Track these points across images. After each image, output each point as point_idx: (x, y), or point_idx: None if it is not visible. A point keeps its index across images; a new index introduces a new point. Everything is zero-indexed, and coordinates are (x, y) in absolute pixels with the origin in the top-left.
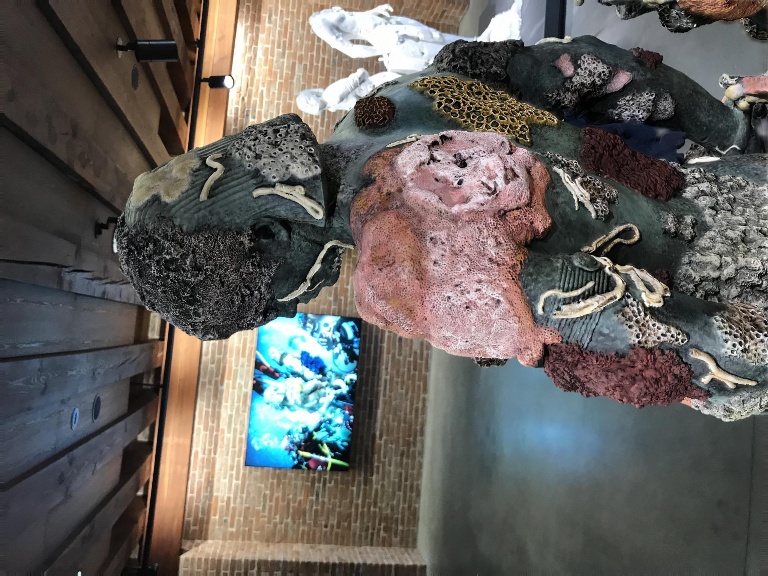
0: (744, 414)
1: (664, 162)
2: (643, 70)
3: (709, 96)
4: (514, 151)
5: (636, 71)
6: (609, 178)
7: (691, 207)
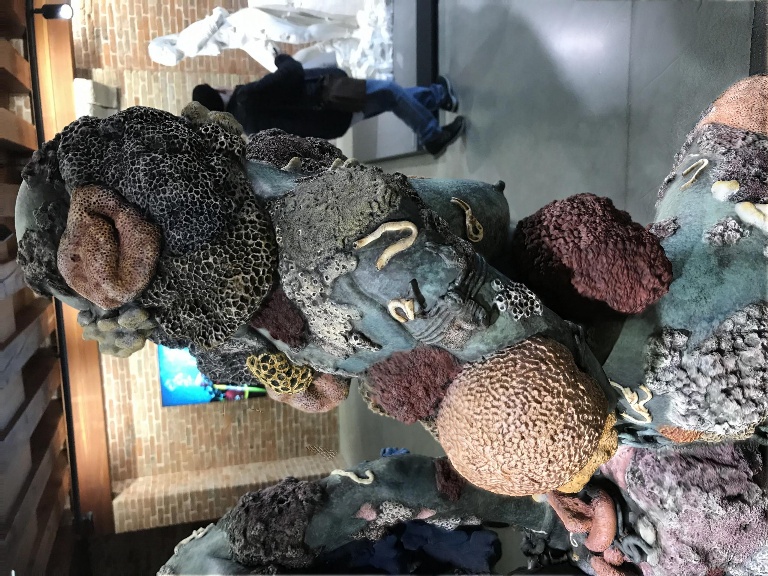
0: None
1: None
2: (446, 504)
3: None
4: None
5: (439, 506)
6: None
7: None
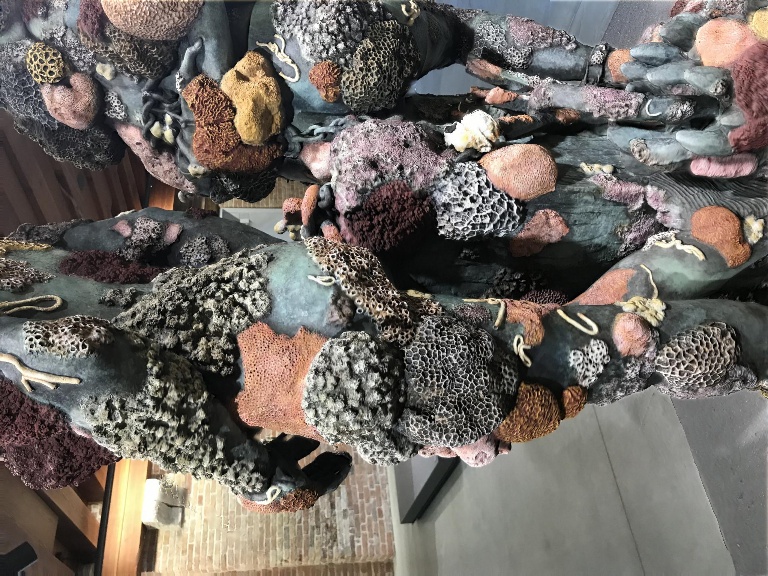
0: (138, 441)
1: None
2: (191, 221)
3: (264, 235)
4: None
5: (185, 223)
6: (71, 275)
7: (146, 285)
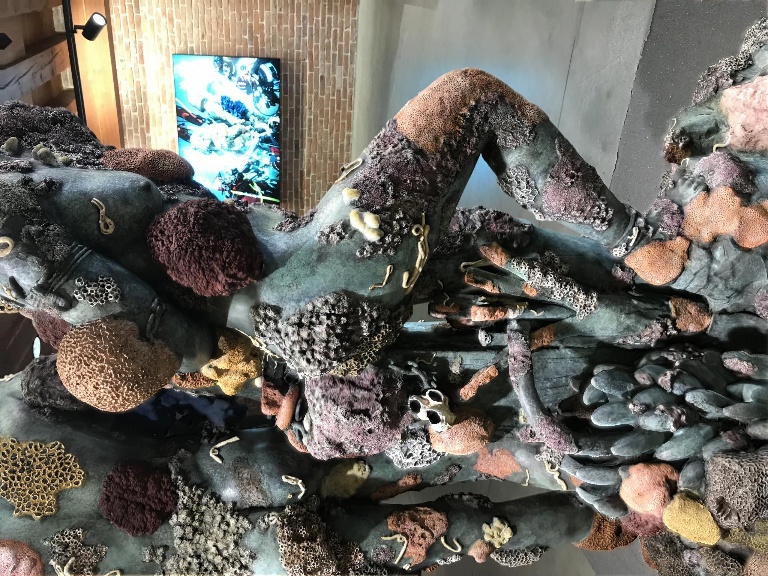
0: None
1: (172, 481)
2: None
3: None
4: (17, 566)
5: None
6: (113, 524)
7: (169, 535)
